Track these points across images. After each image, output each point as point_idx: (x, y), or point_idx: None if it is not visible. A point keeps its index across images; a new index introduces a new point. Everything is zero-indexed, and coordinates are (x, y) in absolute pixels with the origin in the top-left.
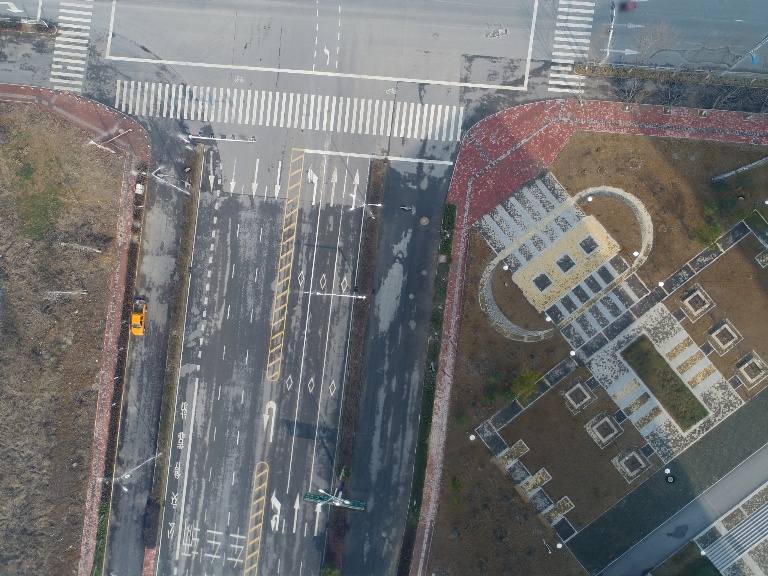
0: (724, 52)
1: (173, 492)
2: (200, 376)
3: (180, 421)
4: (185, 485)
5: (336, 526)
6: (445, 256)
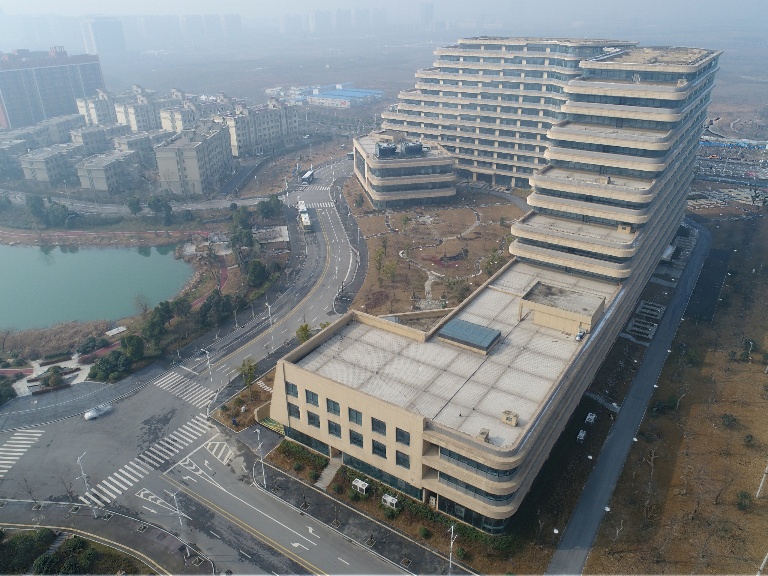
0: None
1: None
2: None
3: None
4: None
5: None
6: None
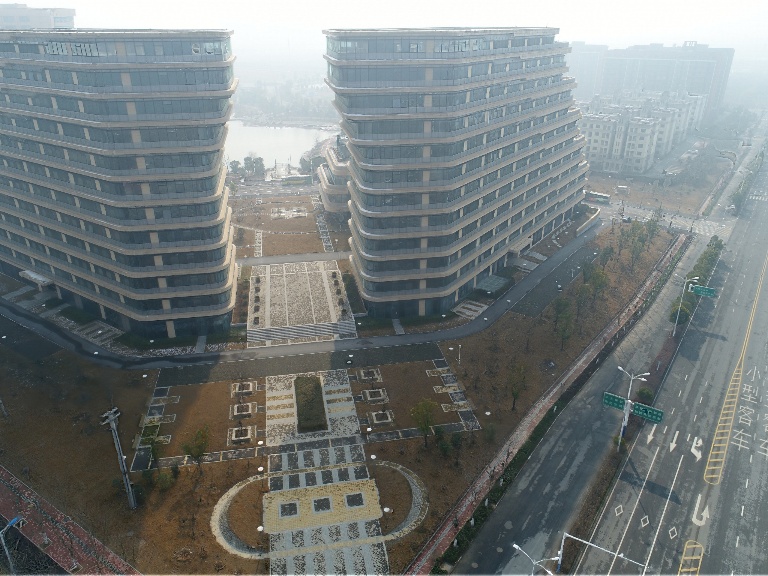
0: (7, 573)
1: None
2: None
3: None
4: None
5: (634, 419)
6: (442, 569)
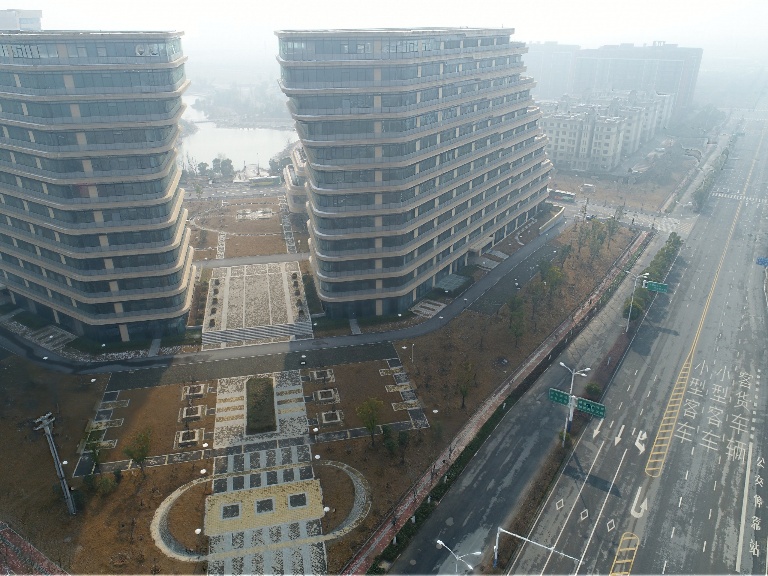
0: None
1: (762, 487)
2: (734, 572)
3: (759, 540)
4: (747, 487)
5: (581, 414)
6: (380, 567)
